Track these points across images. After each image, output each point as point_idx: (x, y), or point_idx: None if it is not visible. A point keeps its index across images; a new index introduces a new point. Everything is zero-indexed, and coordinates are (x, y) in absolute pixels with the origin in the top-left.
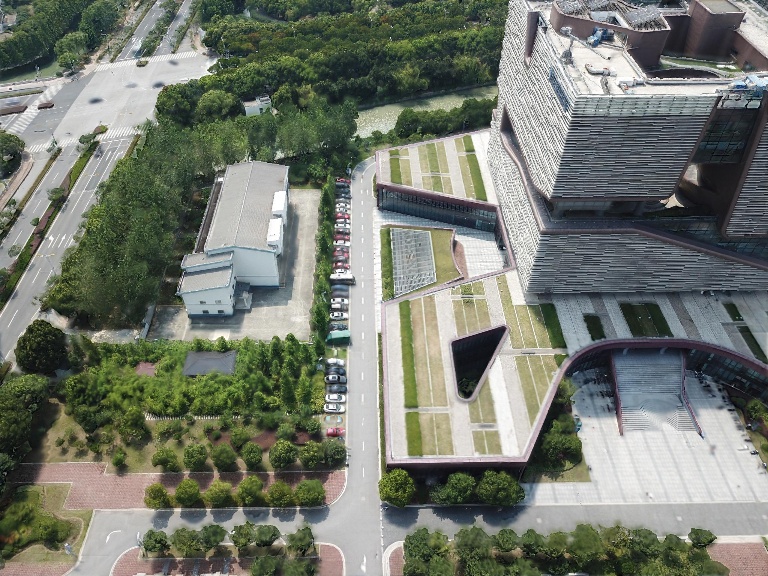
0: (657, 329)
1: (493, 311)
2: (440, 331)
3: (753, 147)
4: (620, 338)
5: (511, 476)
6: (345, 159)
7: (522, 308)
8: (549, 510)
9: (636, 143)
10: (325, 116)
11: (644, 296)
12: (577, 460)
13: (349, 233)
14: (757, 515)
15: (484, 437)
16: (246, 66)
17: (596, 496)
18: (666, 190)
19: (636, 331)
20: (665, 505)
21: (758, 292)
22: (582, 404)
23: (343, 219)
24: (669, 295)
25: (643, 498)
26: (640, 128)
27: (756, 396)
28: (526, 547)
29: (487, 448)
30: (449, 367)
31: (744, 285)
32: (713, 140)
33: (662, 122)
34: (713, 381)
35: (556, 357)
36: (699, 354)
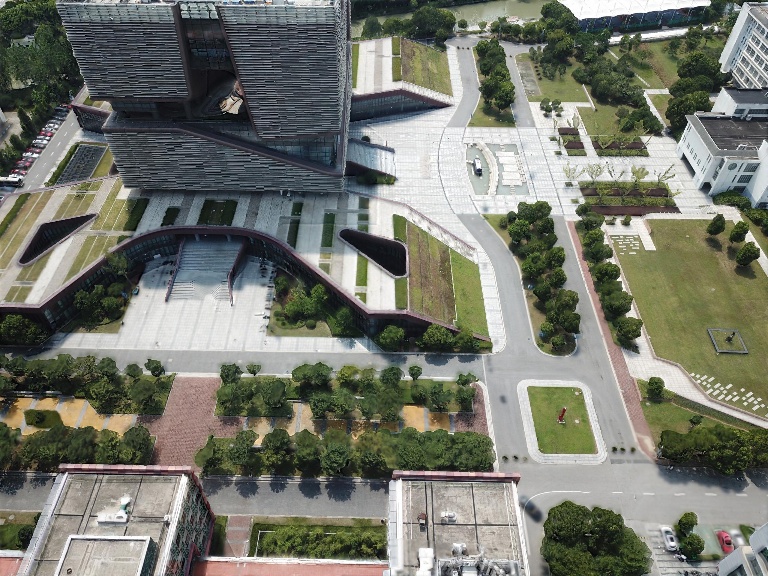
0: (220, 219)
1: (95, 203)
2: (40, 216)
3: (230, 54)
4: (185, 225)
5: (37, 322)
6: (70, 87)
7: (121, 201)
8: (69, 351)
9: (131, 47)
10: (50, 48)
11: (231, 195)
12: (114, 317)
13: (43, 148)
14: (235, 360)
15: (18, 290)
16: (16, 6)
17: (114, 343)
18: (182, 92)
19: (201, 220)
20: (165, 351)
21: (331, 195)
22: (150, 279)
23: (43, 136)
24: (253, 195)
25: (151, 346)
26: (124, 34)
27: (298, 277)
28: (7, 367)
29: (15, 298)
30: (27, 242)
31: (307, 186)
32: (201, 47)
33: (139, 28)
34: (272, 266)
35: (119, 237)
36: (256, 242)
